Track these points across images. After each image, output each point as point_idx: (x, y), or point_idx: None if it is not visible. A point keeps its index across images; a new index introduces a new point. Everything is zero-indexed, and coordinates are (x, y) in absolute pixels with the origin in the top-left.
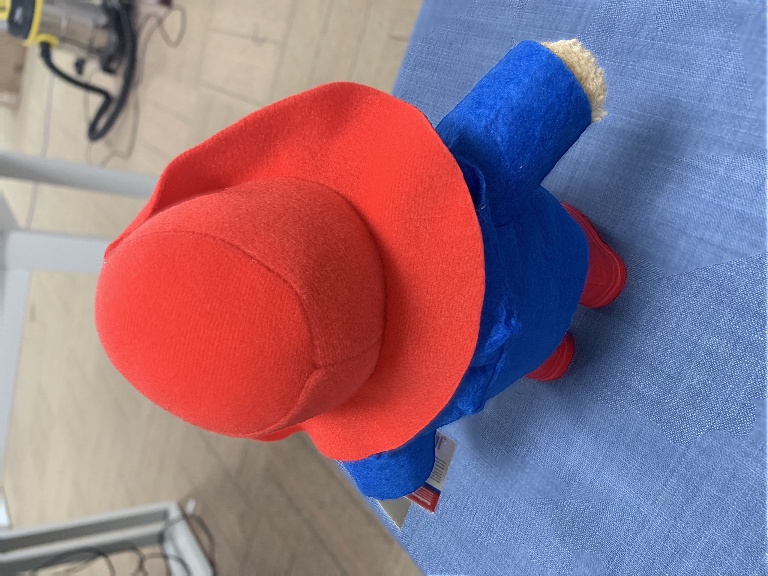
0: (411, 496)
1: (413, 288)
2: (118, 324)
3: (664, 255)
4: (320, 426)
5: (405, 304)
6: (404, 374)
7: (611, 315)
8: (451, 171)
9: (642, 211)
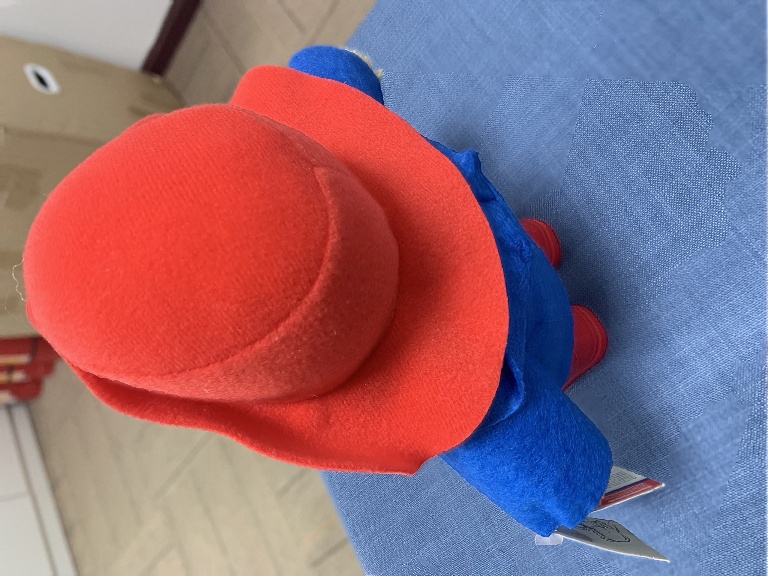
0: (625, 498)
1: (354, 155)
2: (67, 254)
3: (543, 180)
4: (421, 384)
5: (360, 167)
6: (424, 221)
7: (571, 252)
8: (297, 75)
9: (500, 186)
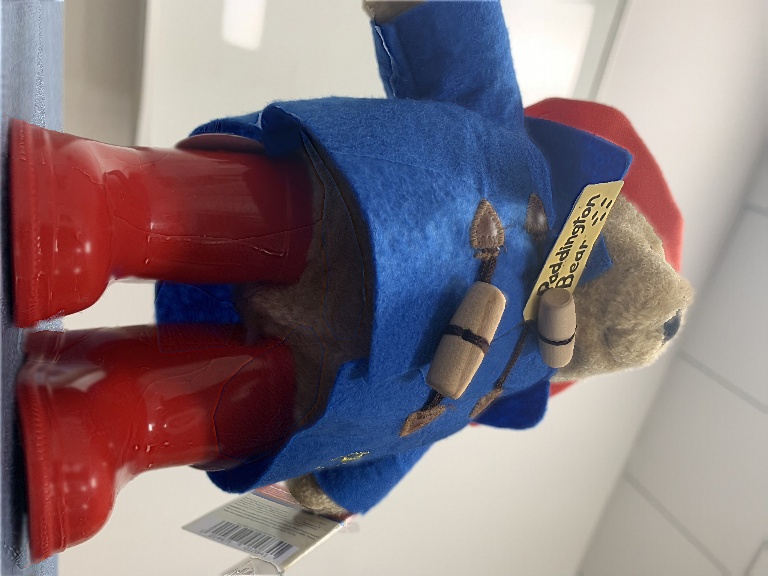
0: None
1: None
2: None
3: None
4: None
5: None
6: None
7: None
8: None
9: None
